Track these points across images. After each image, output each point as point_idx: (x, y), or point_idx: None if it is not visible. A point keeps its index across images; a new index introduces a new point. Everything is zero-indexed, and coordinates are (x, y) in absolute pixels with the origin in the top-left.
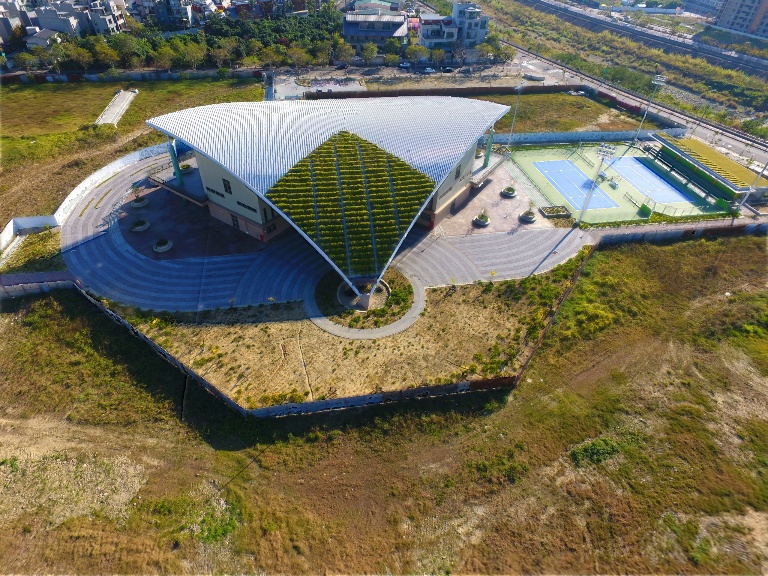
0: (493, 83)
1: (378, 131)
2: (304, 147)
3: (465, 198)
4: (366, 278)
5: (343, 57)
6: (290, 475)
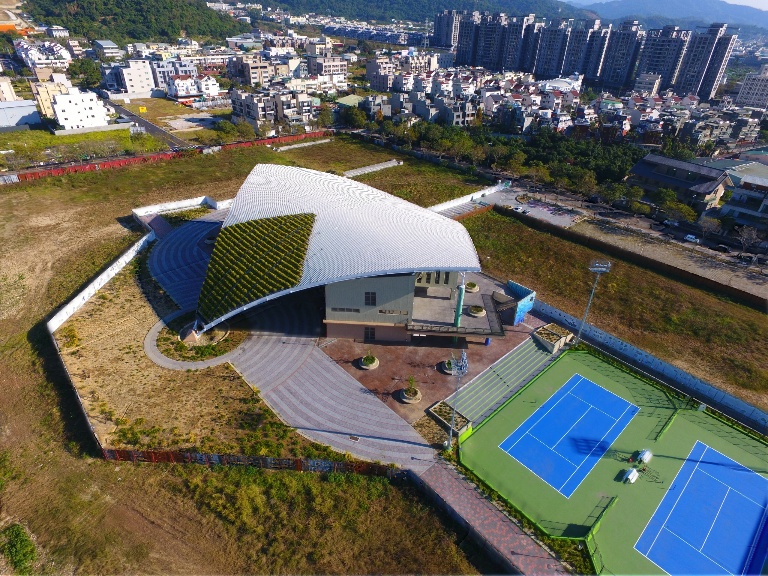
0: (763, 287)
1: (332, 225)
2: (278, 212)
3: (403, 340)
4: (200, 318)
5: (584, 189)
6: (5, 366)
